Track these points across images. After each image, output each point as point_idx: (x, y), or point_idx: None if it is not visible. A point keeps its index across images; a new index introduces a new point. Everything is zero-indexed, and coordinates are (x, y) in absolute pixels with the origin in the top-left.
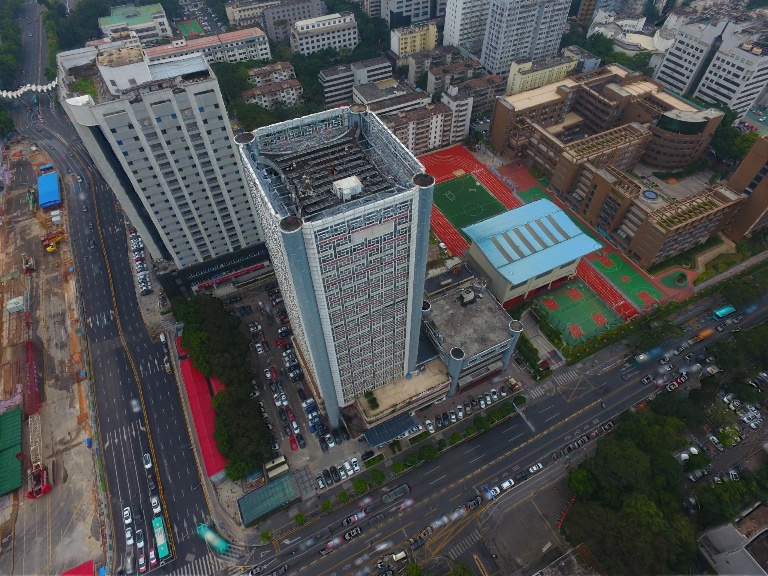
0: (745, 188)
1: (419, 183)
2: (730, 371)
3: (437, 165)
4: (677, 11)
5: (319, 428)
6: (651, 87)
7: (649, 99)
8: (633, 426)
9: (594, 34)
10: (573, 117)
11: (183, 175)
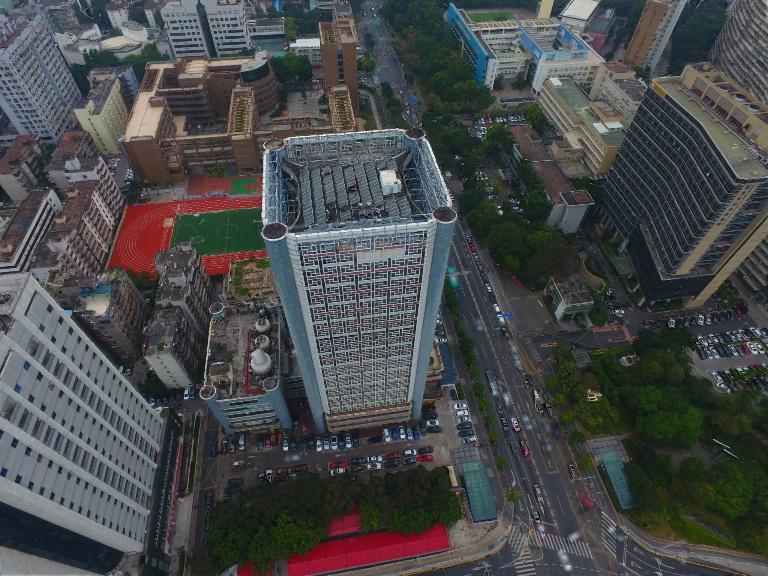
0: (339, 81)
1: (417, 137)
2: (454, 166)
3: (141, 235)
4: (111, 7)
5: (418, 430)
6: (200, 63)
7: (211, 71)
8: (481, 222)
9: (85, 54)
10: (176, 120)
11: (77, 433)
